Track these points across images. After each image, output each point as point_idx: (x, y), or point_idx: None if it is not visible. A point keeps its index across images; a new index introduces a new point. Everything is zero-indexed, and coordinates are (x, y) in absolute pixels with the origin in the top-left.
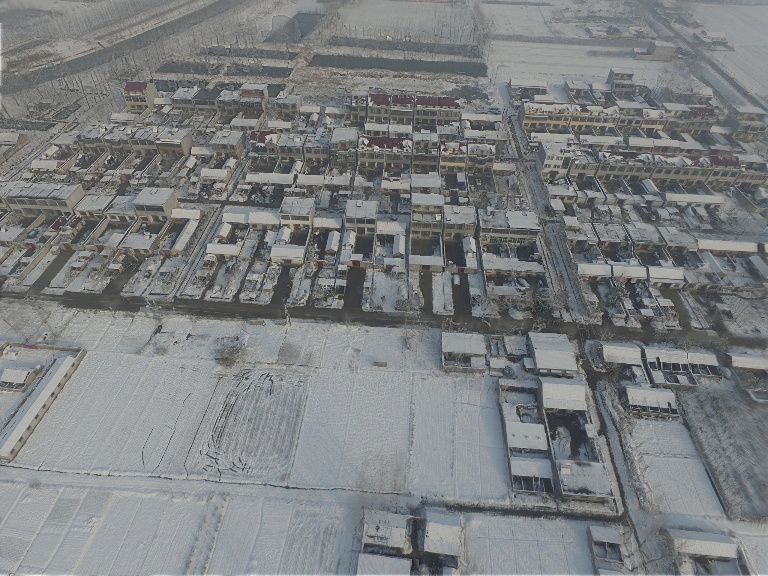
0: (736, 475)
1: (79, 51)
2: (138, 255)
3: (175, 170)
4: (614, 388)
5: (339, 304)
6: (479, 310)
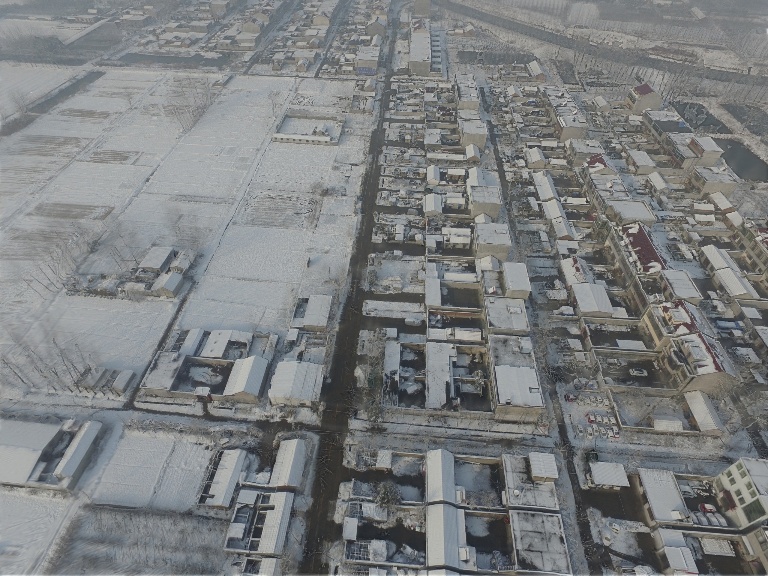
0: (116, 538)
1: (720, 65)
2: (424, 145)
3: (535, 140)
4: (251, 445)
5: (377, 240)
6: (368, 336)
